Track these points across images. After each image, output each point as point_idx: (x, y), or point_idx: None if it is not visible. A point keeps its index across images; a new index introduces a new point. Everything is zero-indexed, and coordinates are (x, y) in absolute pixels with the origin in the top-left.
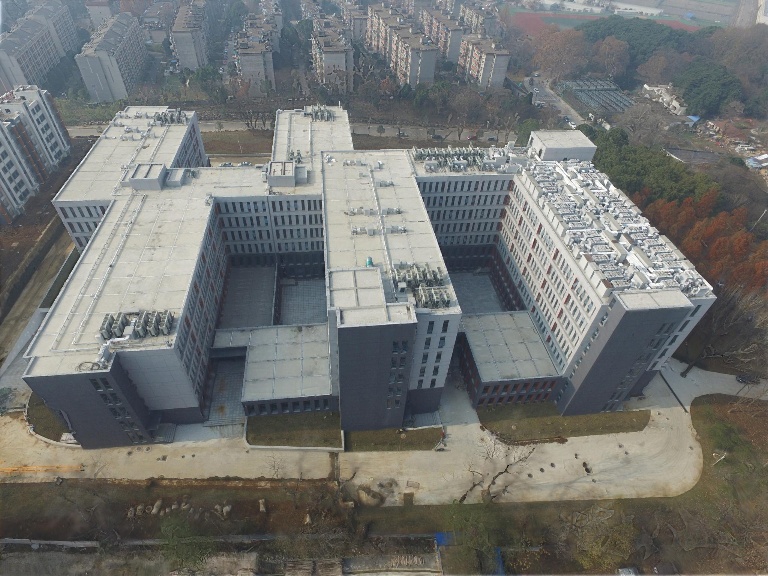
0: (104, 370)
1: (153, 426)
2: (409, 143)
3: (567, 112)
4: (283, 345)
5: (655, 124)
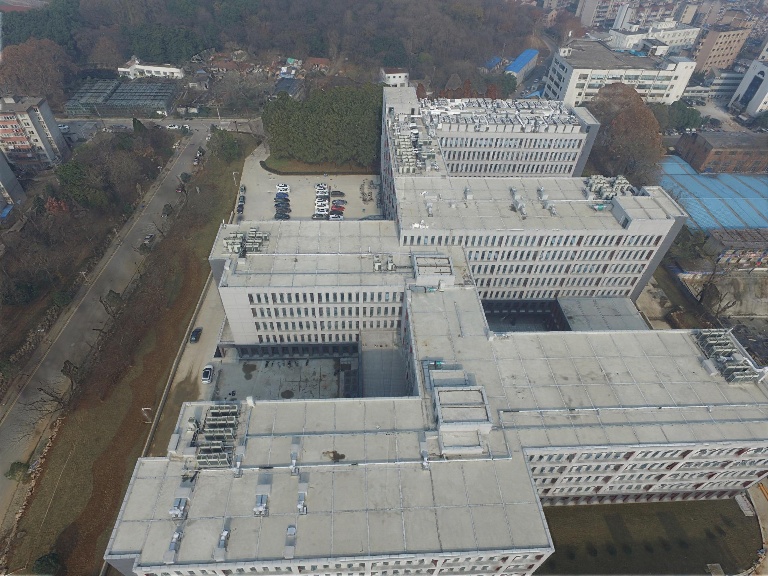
0: None
1: None
2: (186, 232)
3: None
4: (593, 328)
5: None
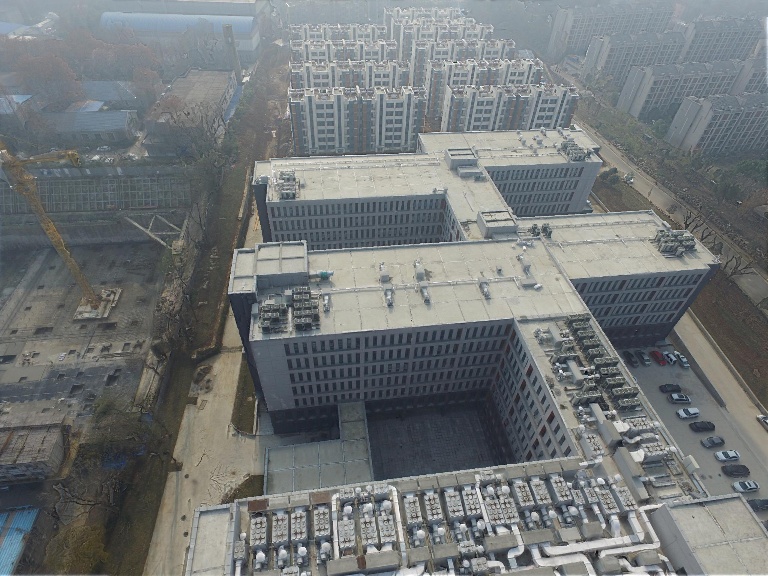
0: (254, 183)
1: (264, 241)
2: None
3: None
4: None
5: None
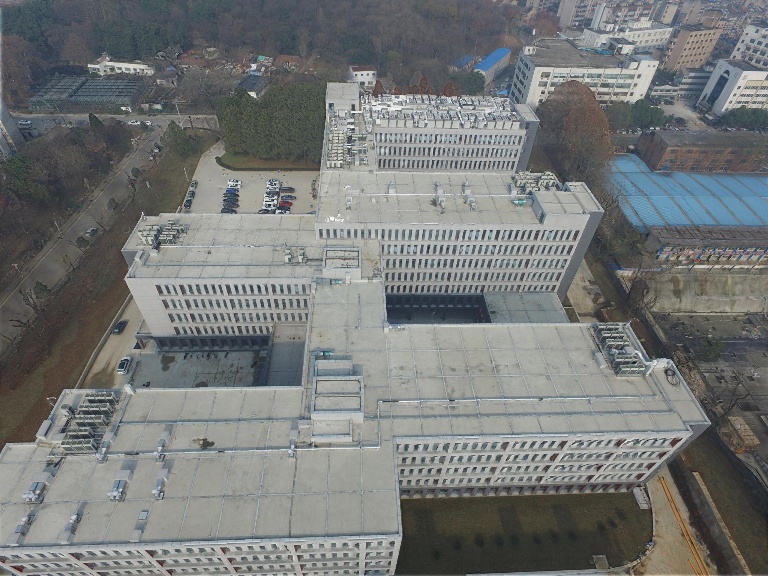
0: None
1: None
2: (128, 226)
3: (100, 119)
4: None
5: (219, 77)
